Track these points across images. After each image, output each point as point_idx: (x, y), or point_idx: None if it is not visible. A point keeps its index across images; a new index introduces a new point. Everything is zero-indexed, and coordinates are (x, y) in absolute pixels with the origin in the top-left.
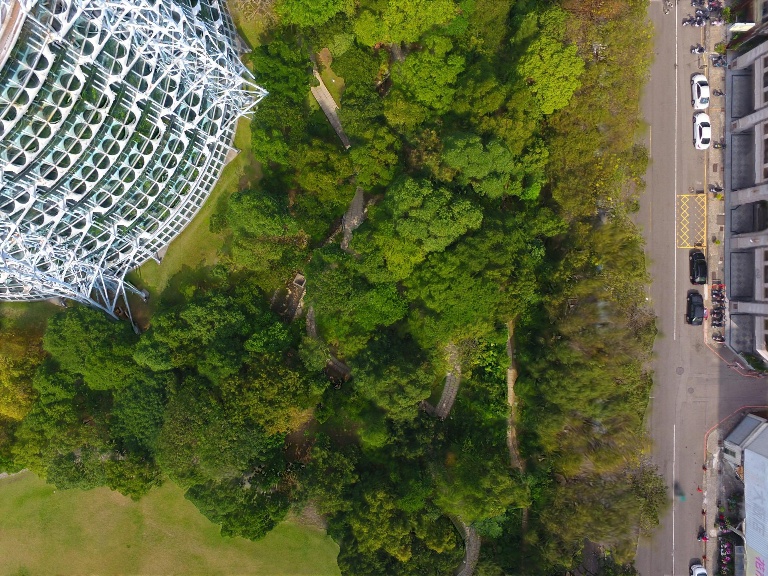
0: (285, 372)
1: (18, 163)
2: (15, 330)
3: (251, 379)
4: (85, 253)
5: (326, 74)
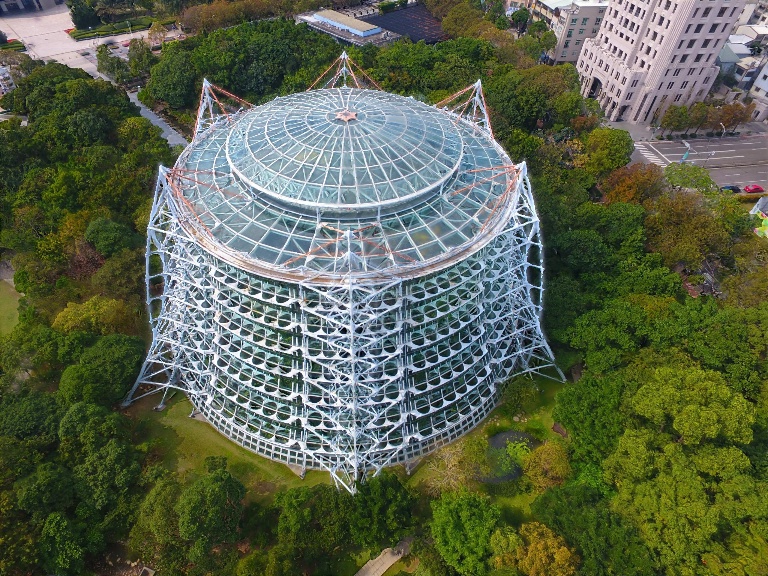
0: (1, 571)
1: (221, 296)
2: (131, 315)
3: (2, 526)
4: (189, 354)
5: (401, 568)
